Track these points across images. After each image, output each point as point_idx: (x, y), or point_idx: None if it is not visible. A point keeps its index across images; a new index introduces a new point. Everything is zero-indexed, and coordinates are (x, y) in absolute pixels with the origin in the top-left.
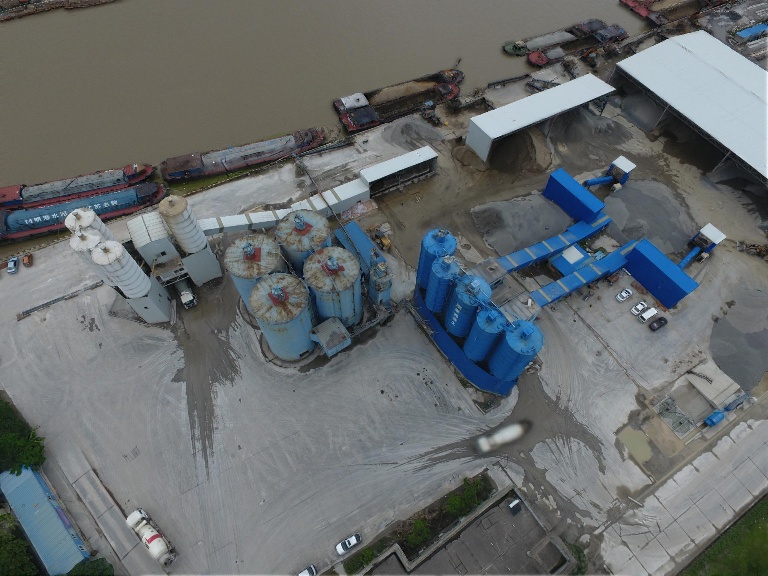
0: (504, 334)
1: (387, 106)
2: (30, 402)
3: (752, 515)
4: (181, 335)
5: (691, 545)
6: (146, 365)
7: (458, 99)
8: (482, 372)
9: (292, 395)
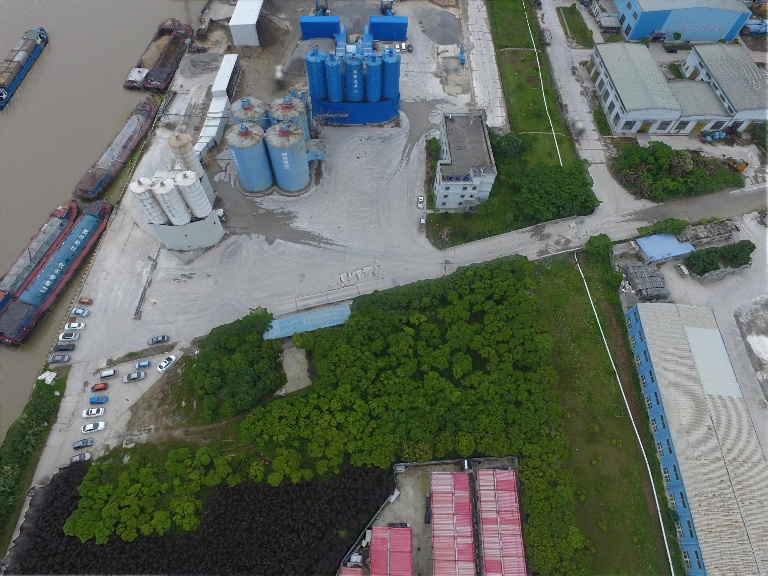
0: (384, 61)
1: (160, 64)
2: (218, 324)
3: (503, 75)
4: (241, 231)
5: (500, 99)
6: (247, 255)
7: (199, 28)
8: (385, 104)
9: (328, 194)
